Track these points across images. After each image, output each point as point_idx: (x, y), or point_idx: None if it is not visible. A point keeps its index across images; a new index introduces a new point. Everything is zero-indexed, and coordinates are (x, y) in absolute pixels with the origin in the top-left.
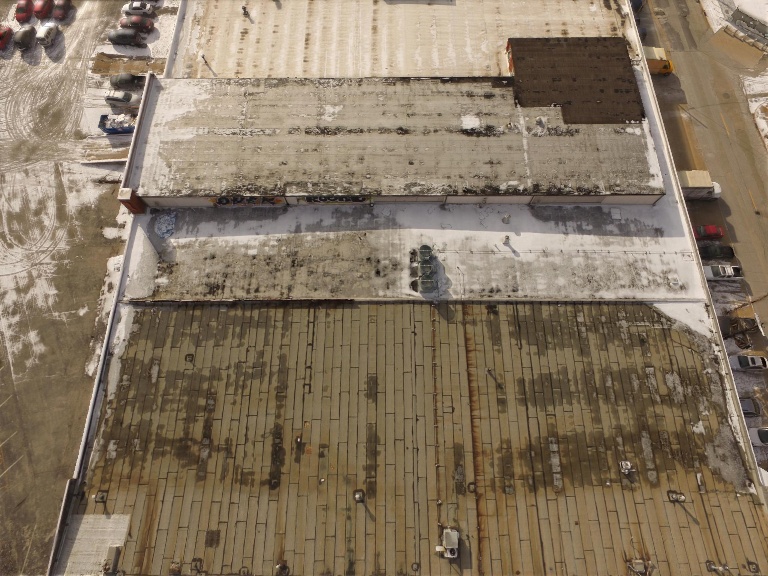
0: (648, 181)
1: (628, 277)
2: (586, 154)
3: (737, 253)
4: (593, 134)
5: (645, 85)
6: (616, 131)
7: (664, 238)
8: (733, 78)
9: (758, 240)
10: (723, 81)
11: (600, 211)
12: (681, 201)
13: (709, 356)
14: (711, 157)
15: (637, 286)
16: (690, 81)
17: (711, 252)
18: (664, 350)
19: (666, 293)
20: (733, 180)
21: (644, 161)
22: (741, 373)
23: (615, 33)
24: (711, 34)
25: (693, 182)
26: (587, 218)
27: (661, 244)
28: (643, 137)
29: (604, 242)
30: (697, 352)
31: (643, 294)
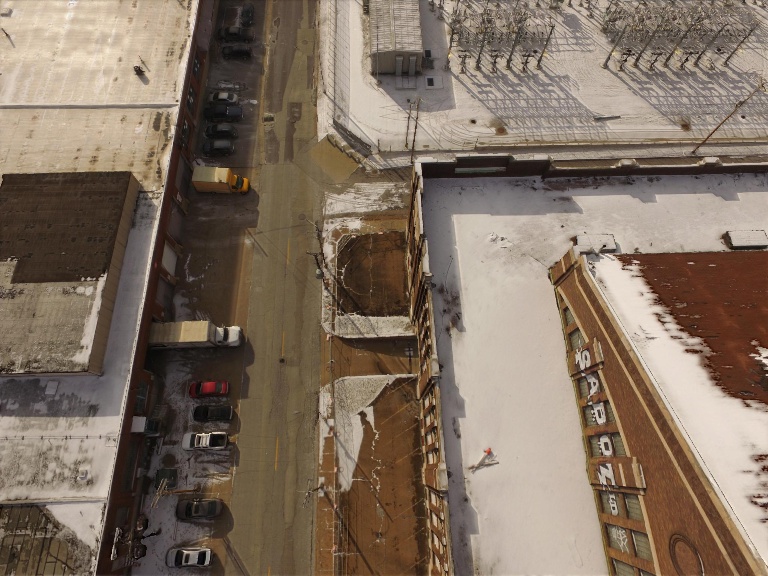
0: (73, 355)
1: (32, 471)
2: (18, 321)
3: (241, 412)
4: (37, 296)
5: (153, 224)
6: (65, 291)
7: (95, 418)
8: (317, 195)
9: (270, 395)
10: (305, 199)
11: (36, 385)
12: (130, 370)
13: (83, 573)
14: (258, 292)
15: (37, 482)
16: (270, 200)
17: (203, 414)
18: (33, 567)
19: (67, 490)
20: (271, 320)
21: (80, 329)
22: (184, 569)
23: (150, 159)
24: (314, 143)
25: (185, 336)
26: (17, 394)
27: (88, 426)
28: (91, 298)
29: (23, 425)
30: (71, 568)
31: (39, 493)
